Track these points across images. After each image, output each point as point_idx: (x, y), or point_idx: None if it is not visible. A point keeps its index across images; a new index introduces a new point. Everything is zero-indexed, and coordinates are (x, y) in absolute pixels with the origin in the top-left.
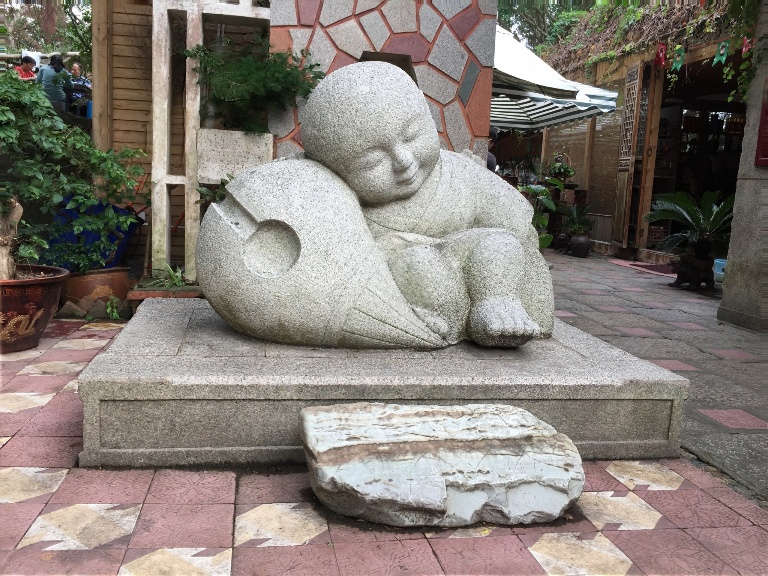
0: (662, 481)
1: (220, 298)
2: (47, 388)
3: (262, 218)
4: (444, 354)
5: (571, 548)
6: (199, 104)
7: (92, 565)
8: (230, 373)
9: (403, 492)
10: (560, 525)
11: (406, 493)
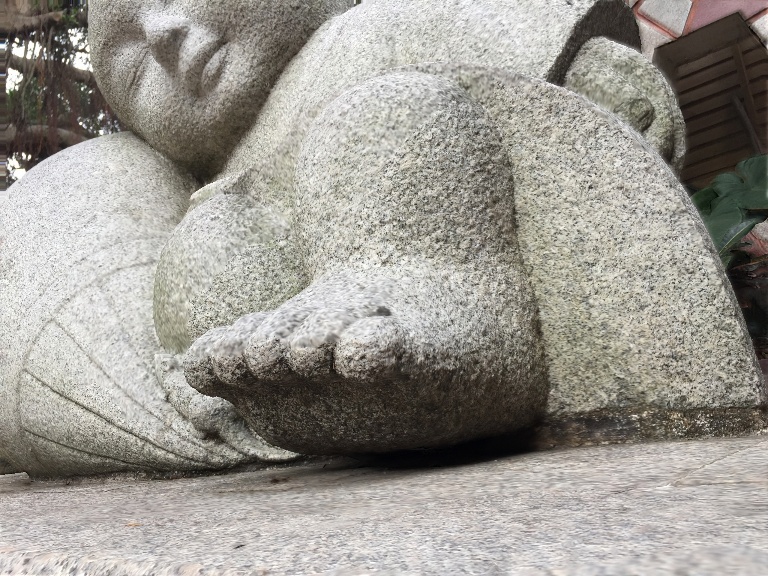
0: None
1: None
2: None
3: None
4: None
5: None
6: None
7: None
8: None
9: None
10: None
11: None
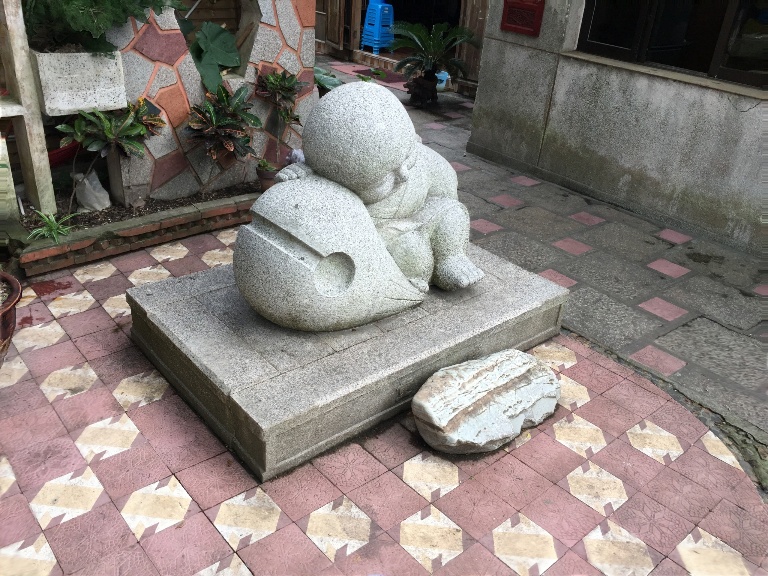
0: (567, 358)
1: (288, 315)
2: (108, 410)
3: (327, 253)
4: (431, 306)
5: (572, 431)
6: (23, 19)
7: (386, 551)
8: (345, 382)
9: (495, 434)
10: (554, 415)
11: (496, 433)
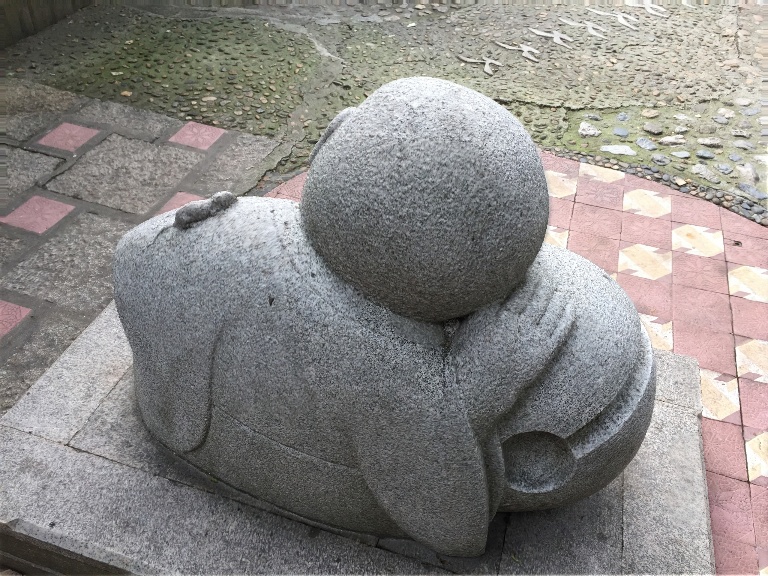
0: None
1: None
2: None
3: None
4: None
5: None
6: None
7: None
8: None
9: None
10: None
11: None
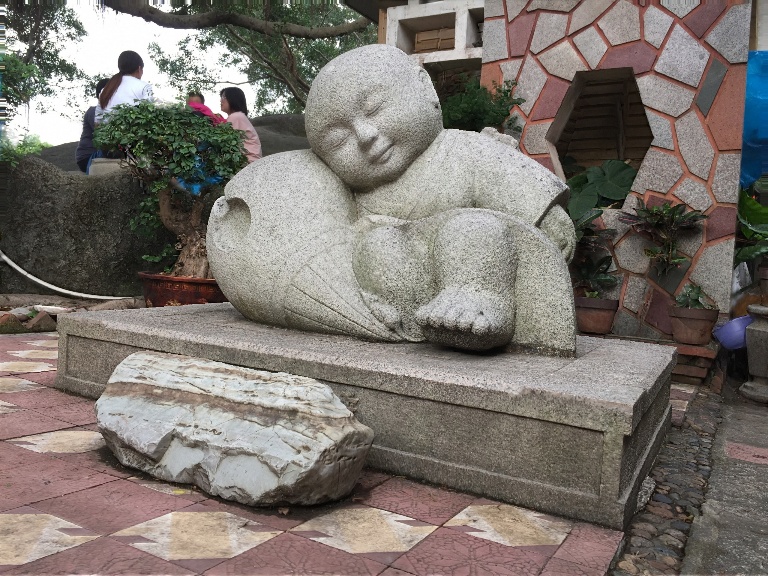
0: (514, 534)
1: None
2: None
3: (229, 197)
4: (380, 345)
5: (211, 526)
6: None
7: None
8: (150, 325)
9: (126, 428)
10: (260, 513)
11: (127, 429)
